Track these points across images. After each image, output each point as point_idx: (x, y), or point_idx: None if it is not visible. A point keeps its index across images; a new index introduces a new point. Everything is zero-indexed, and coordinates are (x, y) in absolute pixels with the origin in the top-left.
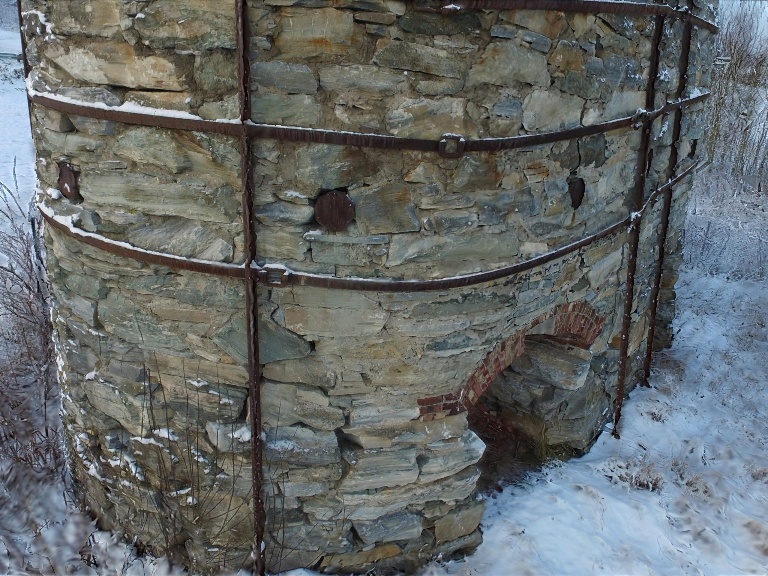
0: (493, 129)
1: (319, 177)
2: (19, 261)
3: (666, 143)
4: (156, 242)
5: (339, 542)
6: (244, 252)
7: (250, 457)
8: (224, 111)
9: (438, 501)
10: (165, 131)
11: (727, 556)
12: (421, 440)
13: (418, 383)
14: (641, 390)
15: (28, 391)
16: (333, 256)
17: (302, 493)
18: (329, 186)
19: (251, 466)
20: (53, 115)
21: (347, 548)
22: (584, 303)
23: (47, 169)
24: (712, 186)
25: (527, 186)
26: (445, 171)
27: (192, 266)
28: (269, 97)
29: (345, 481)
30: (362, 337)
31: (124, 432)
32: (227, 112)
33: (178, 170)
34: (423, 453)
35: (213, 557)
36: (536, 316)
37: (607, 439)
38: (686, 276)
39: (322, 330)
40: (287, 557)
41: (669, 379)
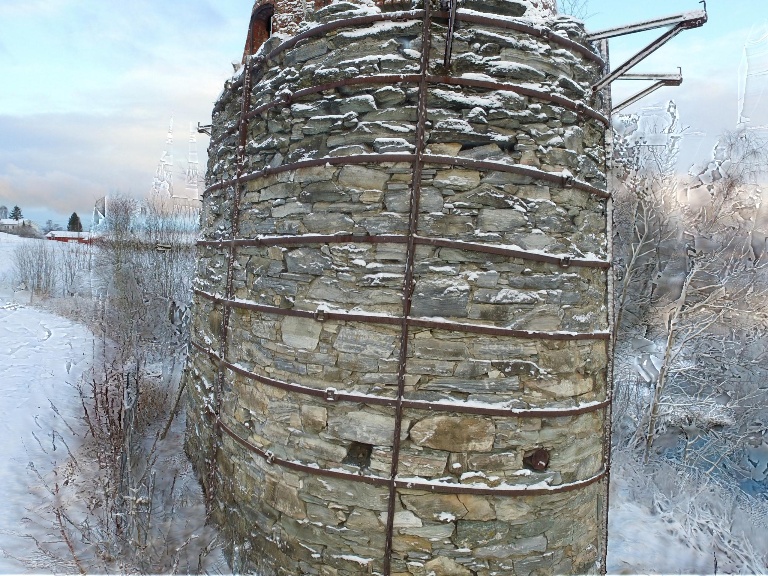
0: None
1: None
2: None
3: None
4: (584, 474)
5: None
6: (601, 462)
7: None
8: None
9: None
10: None
11: None
12: None
13: None
14: None
15: None
16: None
17: None
18: None
19: None
20: None
21: None
22: None
23: None
24: None
25: None
26: None
27: None
28: None
29: None
30: None
31: None
32: None
33: None
34: None
35: None
36: None
37: None
38: None
39: None
40: None
41: None
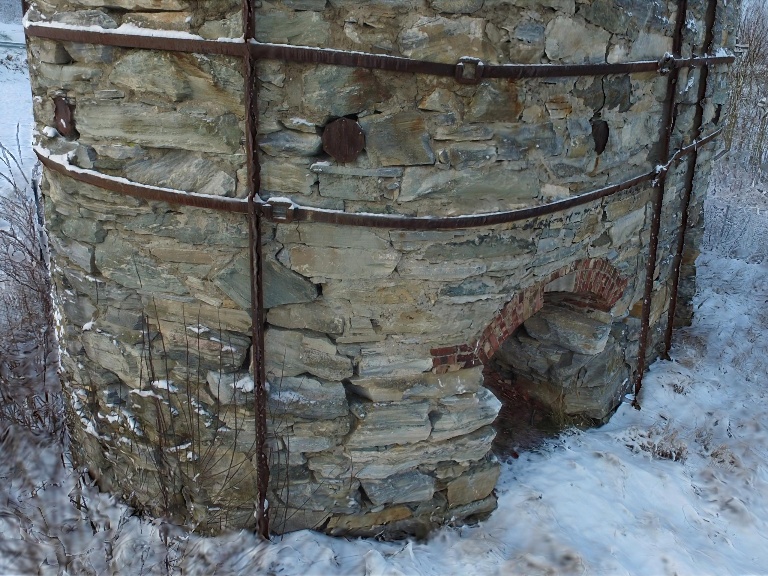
0: (514, 55)
1: (327, 103)
2: (22, 228)
3: (691, 100)
4: (155, 177)
5: (346, 502)
6: (247, 185)
7: (253, 410)
8: (226, 30)
9: (451, 461)
10: (164, 54)
11: (756, 527)
12: (434, 394)
13: (431, 331)
14: (662, 363)
15: (28, 356)
16: (342, 190)
17: (308, 448)
18: (338, 113)
19: (254, 419)
20: (48, 45)
21: (355, 508)
22: (605, 261)
23: (43, 107)
24: (729, 176)
25: (549, 121)
26: (462, 99)
27: (192, 201)
28: (274, 14)
29: (353, 436)
30: (372, 280)
31: (123, 387)
32: (229, 31)
33: (178, 98)
34: (436, 409)
35: (214, 517)
36: (556, 268)
37: (627, 410)
38: (705, 257)
39: (330, 271)
40: (292, 517)
41: (691, 352)
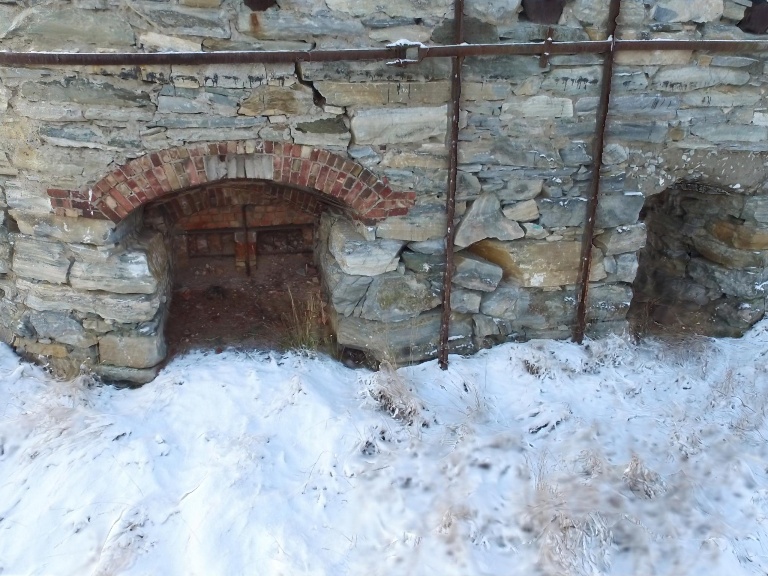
0: None
1: None
2: None
3: None
4: None
5: (17, 324)
6: None
7: None
8: None
9: (96, 314)
10: None
11: (390, 508)
12: (61, 236)
13: (43, 170)
14: None
15: None
16: None
17: None
18: None
19: None
20: None
21: (23, 332)
22: (342, 157)
23: None
24: None
25: None
26: None
27: None
28: None
29: (13, 263)
30: None
31: None
32: None
33: None
34: (74, 255)
35: None
36: (211, 138)
37: (430, 366)
38: None
39: None
40: None
41: (614, 341)
